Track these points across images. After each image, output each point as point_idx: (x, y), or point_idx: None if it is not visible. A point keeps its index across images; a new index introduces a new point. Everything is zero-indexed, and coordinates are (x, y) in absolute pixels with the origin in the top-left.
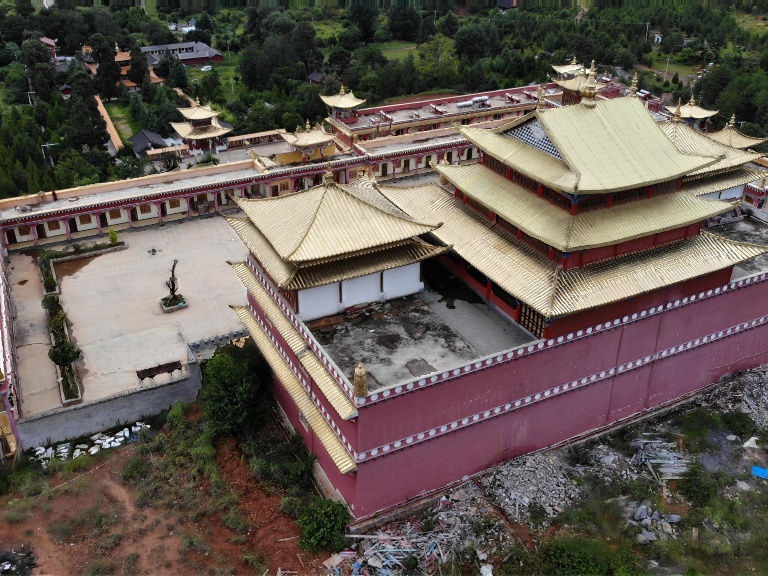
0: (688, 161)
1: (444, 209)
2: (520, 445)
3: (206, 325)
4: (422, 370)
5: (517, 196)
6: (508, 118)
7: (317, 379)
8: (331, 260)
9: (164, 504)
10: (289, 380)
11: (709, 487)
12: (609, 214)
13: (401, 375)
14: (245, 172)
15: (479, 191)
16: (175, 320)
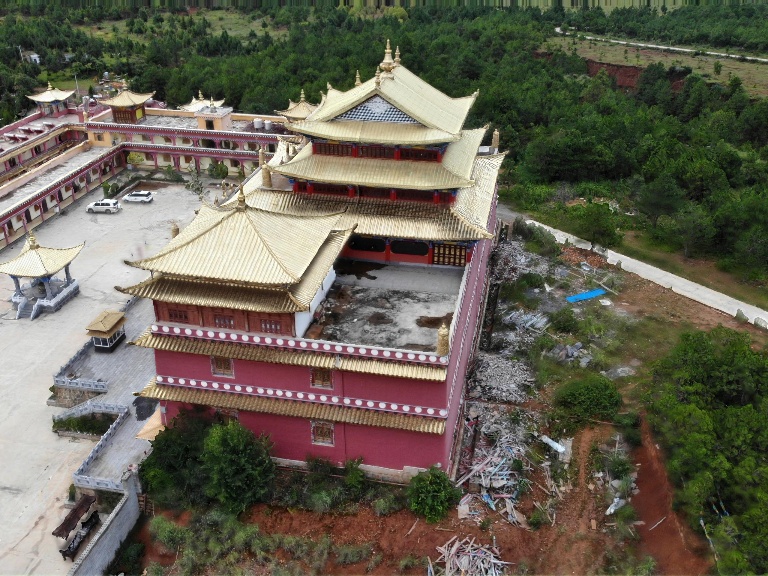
0: (462, 103)
1: (295, 206)
2: (466, 359)
3: (22, 463)
4: (433, 322)
5: (377, 166)
6: (68, 150)
7: (381, 371)
8: None
9: None
10: (298, 409)
11: (571, 318)
12: (450, 155)
13: (429, 333)
14: None
15: (337, 175)
16: None
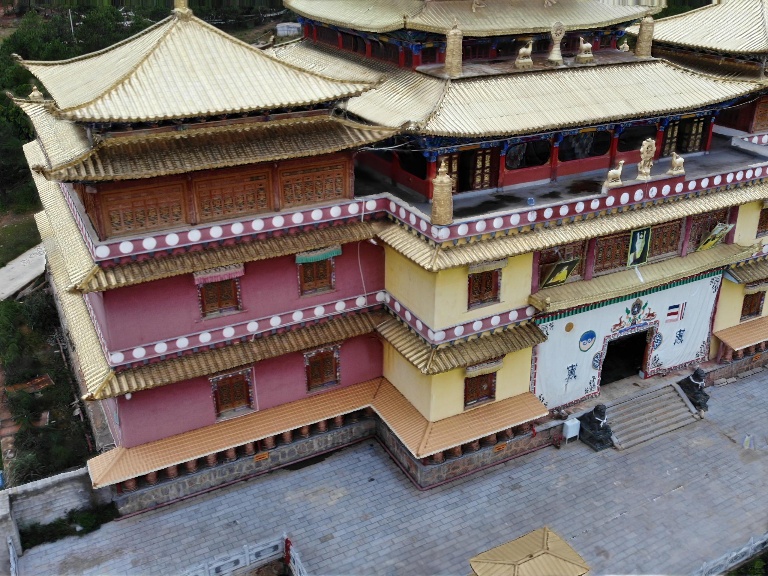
0: None
1: None
2: None
3: None
4: None
5: None
6: None
7: None
8: None
9: None
10: None
11: None
12: None
13: None
14: None
15: None
16: None
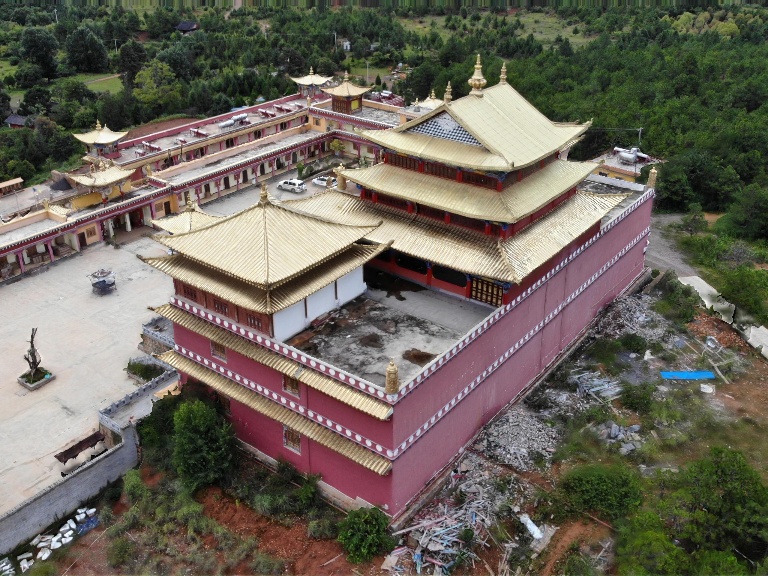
0: (565, 132)
1: (356, 212)
2: (492, 408)
3: (90, 391)
4: (420, 358)
5: (437, 185)
6: (286, 130)
7: (331, 392)
8: (294, 277)
9: (178, 575)
10: (270, 408)
11: (645, 396)
12: (523, 186)
13: (406, 367)
14: (42, 224)
15: (396, 187)
16: (49, 395)
